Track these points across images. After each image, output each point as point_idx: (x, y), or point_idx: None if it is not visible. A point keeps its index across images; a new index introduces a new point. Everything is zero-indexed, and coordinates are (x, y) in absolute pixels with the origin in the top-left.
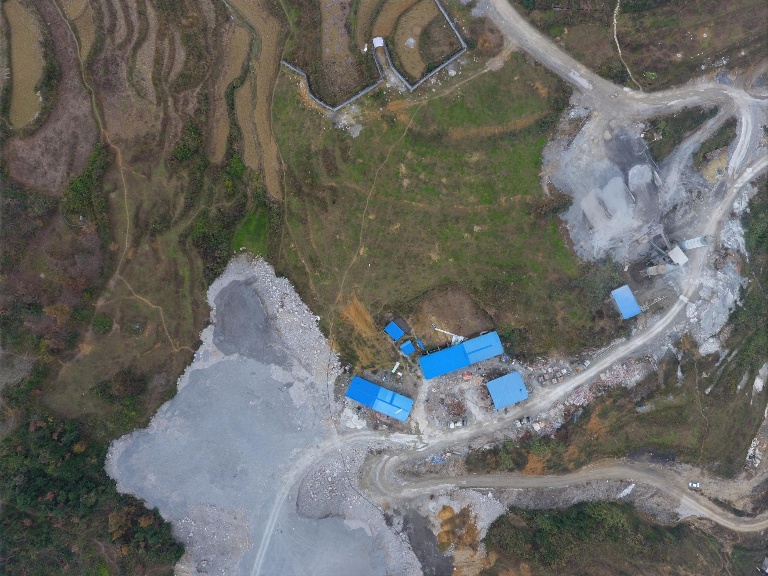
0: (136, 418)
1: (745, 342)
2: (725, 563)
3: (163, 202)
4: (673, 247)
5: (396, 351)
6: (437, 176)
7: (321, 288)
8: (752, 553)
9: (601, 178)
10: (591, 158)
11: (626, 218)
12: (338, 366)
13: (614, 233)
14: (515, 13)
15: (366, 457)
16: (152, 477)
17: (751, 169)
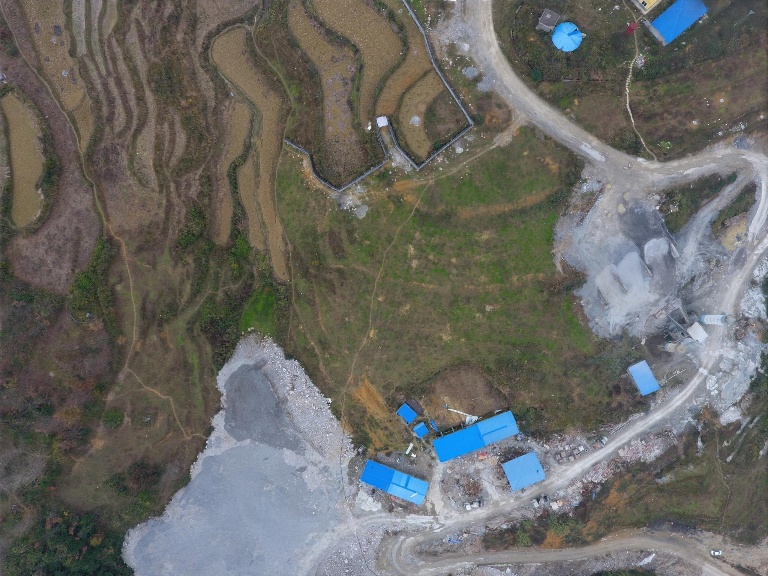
0: (151, 507)
1: (767, 408)
2: None
3: (169, 291)
4: (691, 319)
5: (409, 432)
6: (446, 256)
7: (331, 370)
8: None
9: (616, 254)
10: (605, 233)
11: (642, 292)
12: (351, 448)
13: (630, 308)
14: (523, 86)
15: (382, 538)
16: (169, 566)
17: None
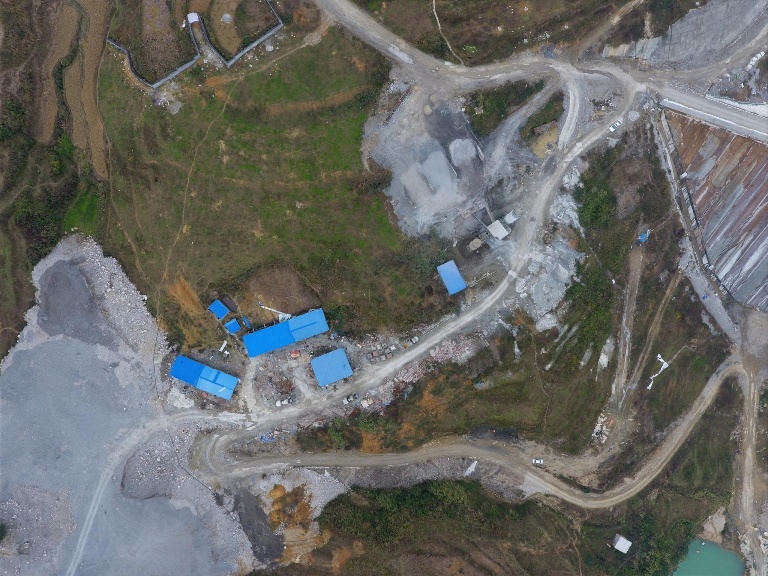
0: None
1: (586, 318)
2: (573, 540)
3: None
4: None
5: (223, 330)
6: (257, 152)
7: (147, 267)
8: (601, 529)
9: (421, 153)
10: (411, 133)
11: (450, 193)
12: (165, 345)
13: (438, 208)
14: None
15: (196, 437)
16: None
17: (581, 143)
